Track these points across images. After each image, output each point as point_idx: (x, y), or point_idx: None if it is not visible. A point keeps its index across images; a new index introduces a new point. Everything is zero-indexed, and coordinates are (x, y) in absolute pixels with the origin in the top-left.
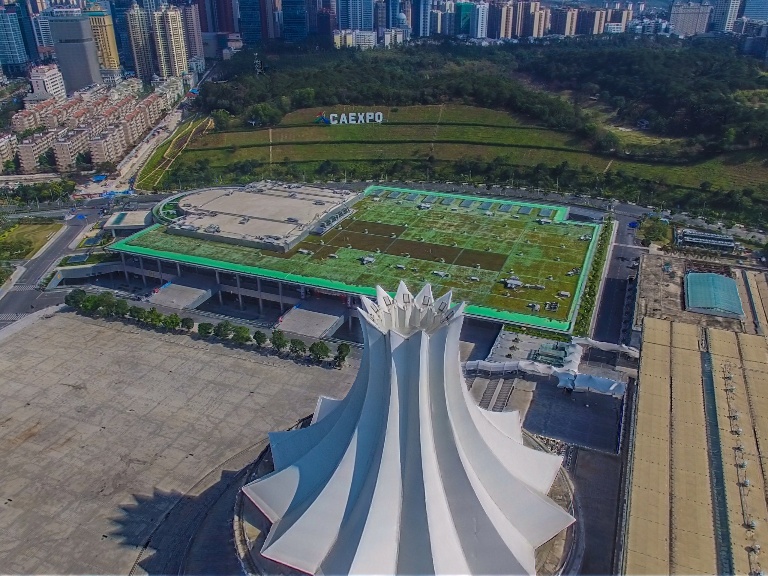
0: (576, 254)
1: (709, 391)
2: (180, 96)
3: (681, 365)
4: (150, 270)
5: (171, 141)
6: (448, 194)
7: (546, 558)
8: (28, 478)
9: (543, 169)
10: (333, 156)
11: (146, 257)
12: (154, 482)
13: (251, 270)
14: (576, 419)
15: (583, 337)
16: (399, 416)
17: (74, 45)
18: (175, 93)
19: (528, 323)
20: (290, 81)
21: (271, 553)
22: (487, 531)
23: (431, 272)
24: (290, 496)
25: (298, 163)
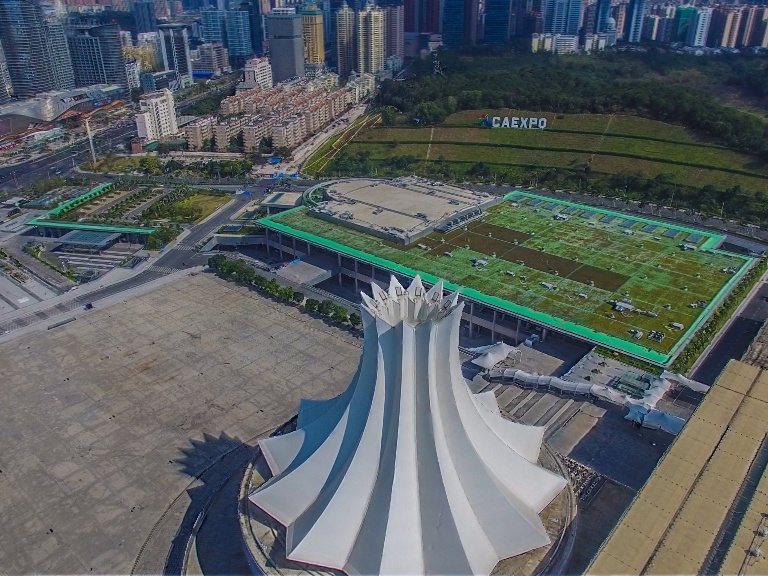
0: (710, 286)
1: (766, 449)
2: (370, 92)
3: (747, 416)
4: (287, 246)
5: (343, 132)
6: (592, 207)
7: (512, 572)
8: (132, 402)
9: (709, 192)
10: (488, 159)
11: (283, 234)
12: (224, 427)
13: (367, 257)
14: (635, 455)
15: (677, 373)
16: (385, 400)
17: (285, 41)
18: (365, 89)
19: (622, 349)
20: (465, 82)
21: (257, 499)
22: (448, 528)
23: (540, 283)
24: (293, 456)
25: (452, 162)
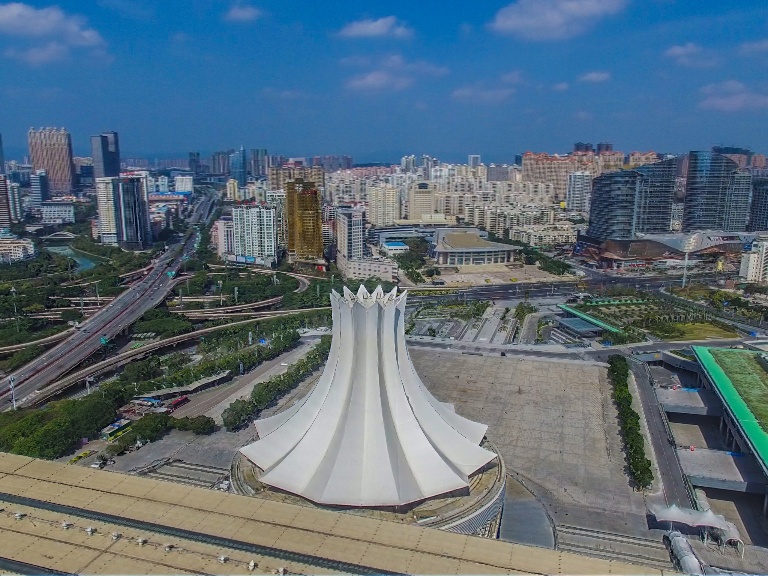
0: None
1: None
2: None
3: None
4: None
5: None
6: None
7: None
8: None
9: None
10: None
11: None
12: None
13: (733, 402)
14: None
15: None
16: None
17: None
18: None
19: None
20: None
21: None
22: None
23: None
24: None
25: None
